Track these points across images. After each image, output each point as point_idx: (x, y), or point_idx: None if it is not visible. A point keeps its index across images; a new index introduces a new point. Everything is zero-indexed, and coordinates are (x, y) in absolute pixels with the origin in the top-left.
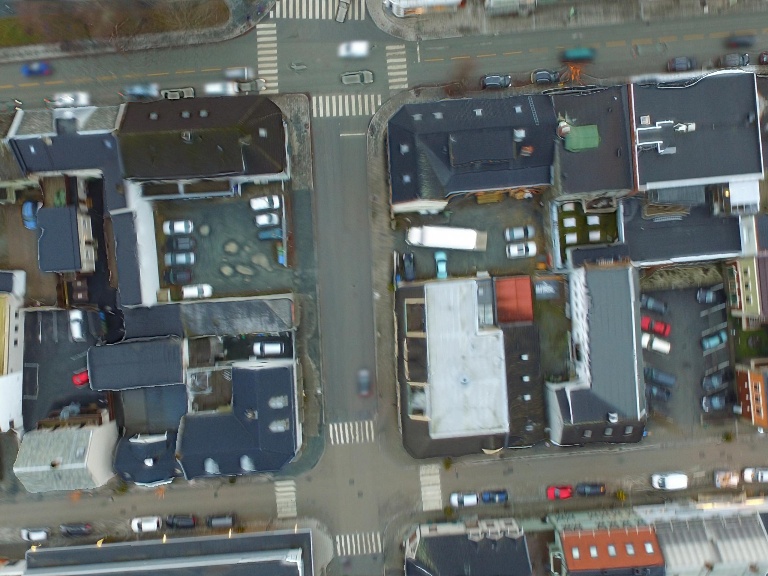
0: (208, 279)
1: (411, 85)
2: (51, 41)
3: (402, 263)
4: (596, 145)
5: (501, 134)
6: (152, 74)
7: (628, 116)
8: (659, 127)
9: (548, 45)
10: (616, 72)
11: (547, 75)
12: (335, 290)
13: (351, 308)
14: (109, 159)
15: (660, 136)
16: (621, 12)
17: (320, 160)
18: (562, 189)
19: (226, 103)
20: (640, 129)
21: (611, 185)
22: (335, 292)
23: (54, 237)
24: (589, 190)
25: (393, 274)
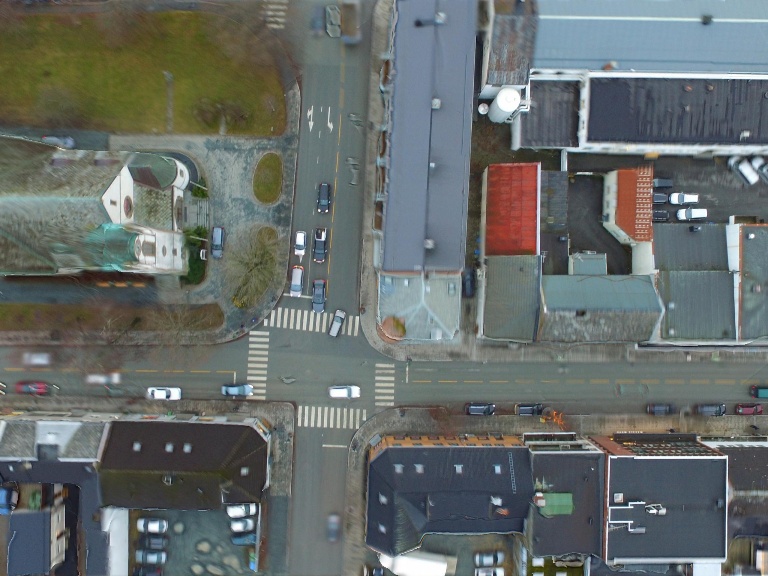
0: None
1: (397, 404)
2: (42, 329)
3: None
4: (569, 512)
5: (478, 497)
6: (141, 370)
7: (603, 488)
8: (631, 507)
9: (534, 378)
10: (597, 409)
11: (530, 410)
12: None
13: None
14: (88, 479)
15: (631, 516)
16: (608, 352)
17: (300, 469)
18: (533, 552)
19: (211, 432)
20: (613, 508)
21: (580, 550)
22: None
23: (25, 541)
24: (559, 553)
25: None
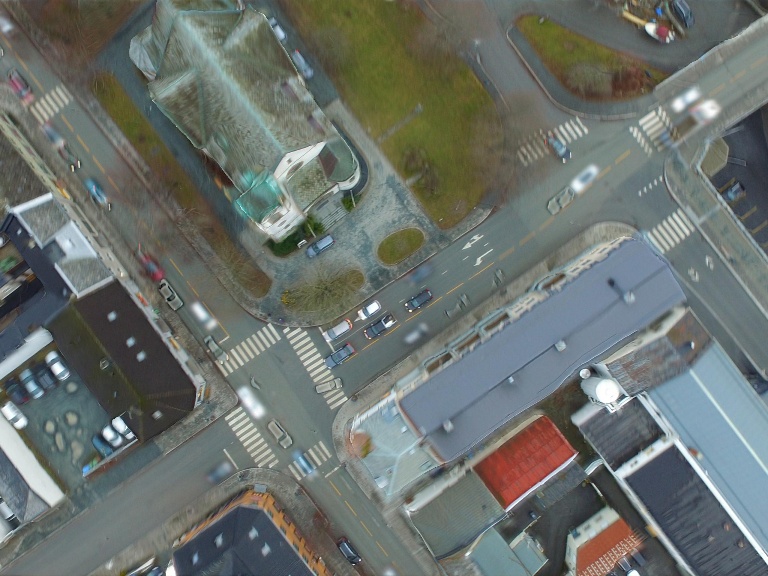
0: (32, 416)
1: (302, 482)
2: (147, 161)
3: (149, 571)
4: None
5: None
6: (174, 262)
7: None
8: None
9: (407, 574)
10: None
11: None
12: (93, 526)
13: (87, 548)
14: (57, 296)
15: None
16: None
17: (192, 446)
18: None
19: (168, 363)
20: None
21: None
22: (92, 527)
23: None
24: None
25: (135, 569)
